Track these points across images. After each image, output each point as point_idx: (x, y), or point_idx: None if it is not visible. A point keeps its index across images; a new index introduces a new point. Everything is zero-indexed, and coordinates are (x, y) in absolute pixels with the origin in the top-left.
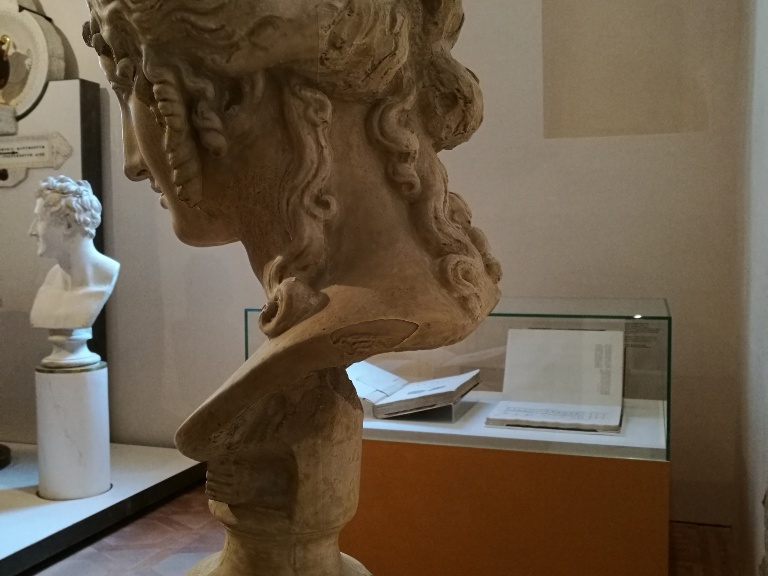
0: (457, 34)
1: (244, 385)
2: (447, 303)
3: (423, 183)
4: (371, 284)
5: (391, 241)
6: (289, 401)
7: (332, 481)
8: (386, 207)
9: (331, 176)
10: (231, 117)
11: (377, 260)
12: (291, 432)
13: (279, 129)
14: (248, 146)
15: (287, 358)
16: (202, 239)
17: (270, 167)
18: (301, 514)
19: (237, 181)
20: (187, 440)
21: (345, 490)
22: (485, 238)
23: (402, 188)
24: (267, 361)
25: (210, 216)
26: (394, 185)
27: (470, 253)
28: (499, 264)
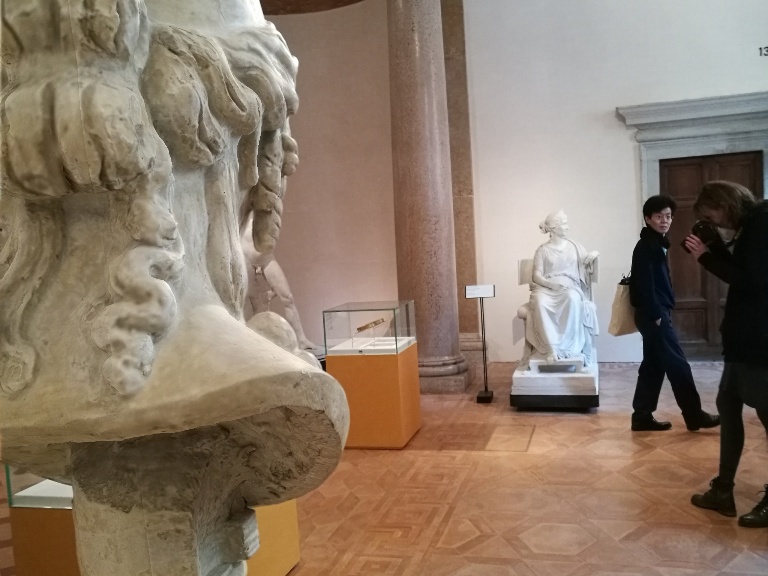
0: (64, 33)
1: None
2: None
3: None
4: None
5: None
6: None
7: None
8: None
9: None
10: None
11: None
12: None
13: None
14: None
15: None
16: None
17: None
18: None
19: None
20: None
21: None
22: (94, 323)
23: None
24: None
25: None
26: None
27: None
28: (103, 365)
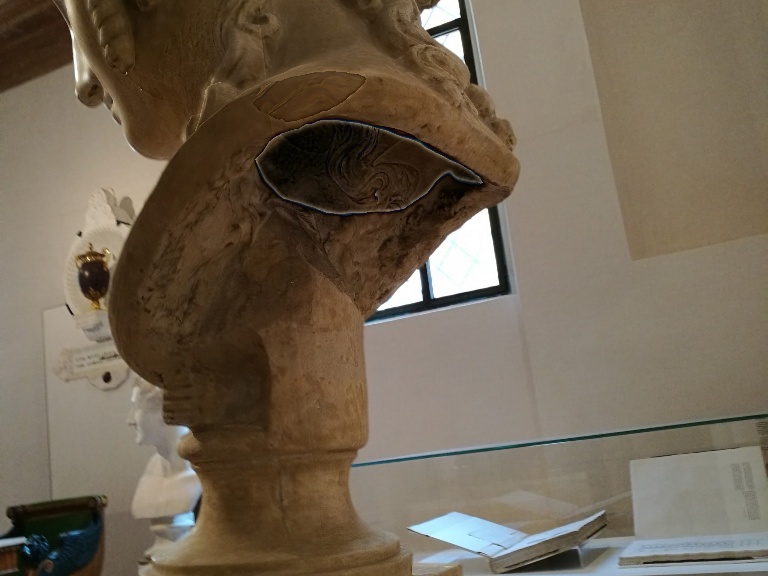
0: None
1: (158, 196)
2: (412, 79)
3: (385, 1)
4: (310, 62)
5: (344, 44)
6: (252, 279)
7: (318, 380)
8: (339, 21)
9: None
10: None
11: (324, 55)
12: (257, 315)
13: None
14: None
15: (202, 140)
16: (154, 137)
17: (206, 10)
18: (279, 422)
19: (175, 41)
20: (118, 320)
21: (340, 398)
22: (484, 91)
23: (358, 3)
24: (179, 152)
25: (154, 97)
26: (349, 4)
27: None
28: (507, 121)
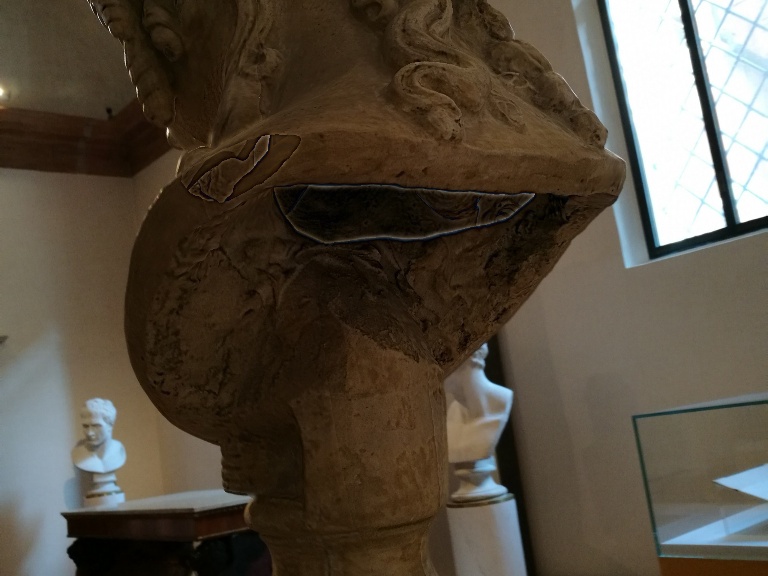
0: None
1: (132, 287)
2: (383, 117)
3: (402, 3)
4: (271, 116)
5: (337, 74)
6: (285, 342)
7: (357, 452)
8: (344, 42)
9: (277, 28)
10: (180, 7)
11: (304, 96)
12: (289, 383)
13: (229, 2)
14: (207, 37)
15: (150, 229)
16: None
17: None
18: (315, 501)
19: (209, 86)
20: None
21: (388, 469)
22: (557, 80)
23: (368, 14)
24: (136, 242)
25: (207, 144)
26: (360, 16)
27: (462, 65)
28: (589, 113)
